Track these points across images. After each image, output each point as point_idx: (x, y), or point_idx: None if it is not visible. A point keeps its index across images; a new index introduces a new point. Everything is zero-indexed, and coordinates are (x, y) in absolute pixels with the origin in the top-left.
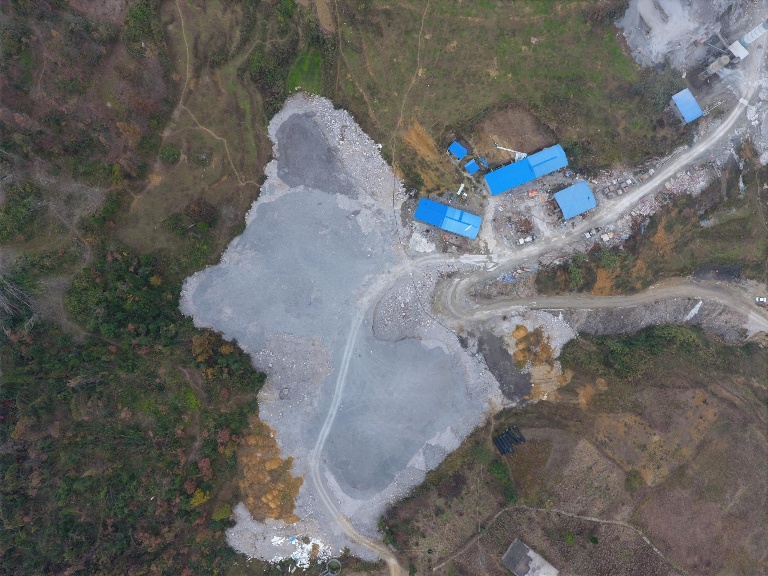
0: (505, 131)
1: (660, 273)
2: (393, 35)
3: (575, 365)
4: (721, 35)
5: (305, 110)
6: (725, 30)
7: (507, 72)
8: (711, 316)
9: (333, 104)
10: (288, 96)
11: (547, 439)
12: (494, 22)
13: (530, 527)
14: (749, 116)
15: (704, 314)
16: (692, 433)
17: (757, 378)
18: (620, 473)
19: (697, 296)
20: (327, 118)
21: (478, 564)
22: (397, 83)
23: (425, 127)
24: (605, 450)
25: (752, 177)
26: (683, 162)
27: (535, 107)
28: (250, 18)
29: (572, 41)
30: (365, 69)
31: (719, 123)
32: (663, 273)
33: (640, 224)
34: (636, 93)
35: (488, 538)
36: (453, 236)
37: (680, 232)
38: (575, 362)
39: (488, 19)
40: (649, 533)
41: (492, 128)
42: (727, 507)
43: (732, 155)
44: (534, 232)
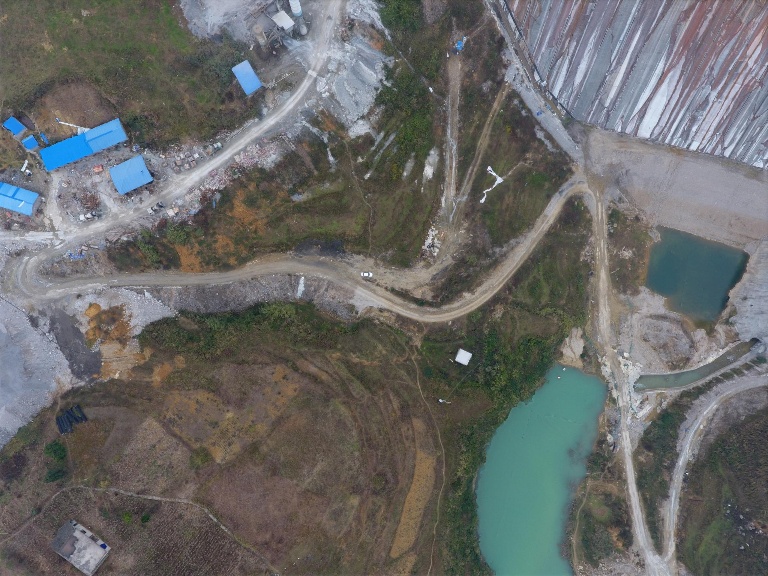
0: (67, 106)
1: (254, 249)
2: None
3: (154, 343)
4: (279, 6)
5: None
6: None
7: (62, 45)
8: (319, 292)
9: None
10: None
11: (111, 418)
12: None
13: (86, 507)
14: (319, 88)
15: (312, 290)
16: (269, 409)
17: (358, 353)
18: (185, 451)
19: (299, 272)
20: None
21: (31, 546)
22: None
23: None
24: (172, 428)
25: (340, 150)
26: (253, 135)
27: (96, 81)
28: None
29: (125, 13)
30: None
31: (288, 95)
32: (258, 249)
33: (210, 198)
34: (195, 65)
35: (43, 519)
36: (16, 213)
37: (270, 207)
38: (156, 340)
39: None
40: (215, 511)
41: (54, 103)
42: (304, 483)
43: (306, 128)
44: (101, 208)
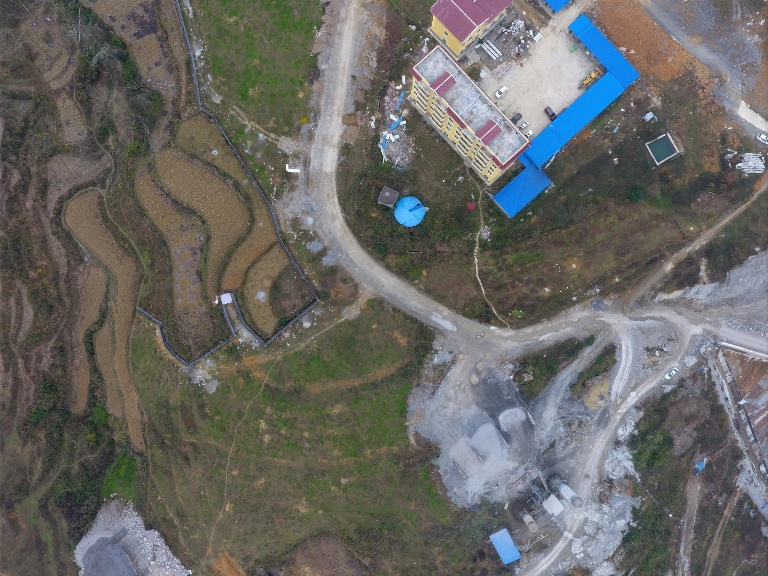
0: (318, 563)
1: None
2: (199, 469)
3: None
4: (542, 475)
5: (114, 531)
6: (551, 458)
7: (317, 509)
8: None
9: (144, 524)
10: (102, 505)
11: None
12: (302, 464)
13: None
14: (574, 549)
15: None
16: None
17: None
18: None
19: None
20: (139, 535)
21: None
22: (205, 515)
23: (235, 558)
24: None
25: None
26: None
27: (348, 540)
28: (54, 445)
29: (384, 481)
30: (174, 494)
31: (542, 556)
32: None
33: None
34: None
35: None
36: None
37: None
38: None
39: (295, 461)
40: None
41: (304, 560)
42: None
43: None
44: None
